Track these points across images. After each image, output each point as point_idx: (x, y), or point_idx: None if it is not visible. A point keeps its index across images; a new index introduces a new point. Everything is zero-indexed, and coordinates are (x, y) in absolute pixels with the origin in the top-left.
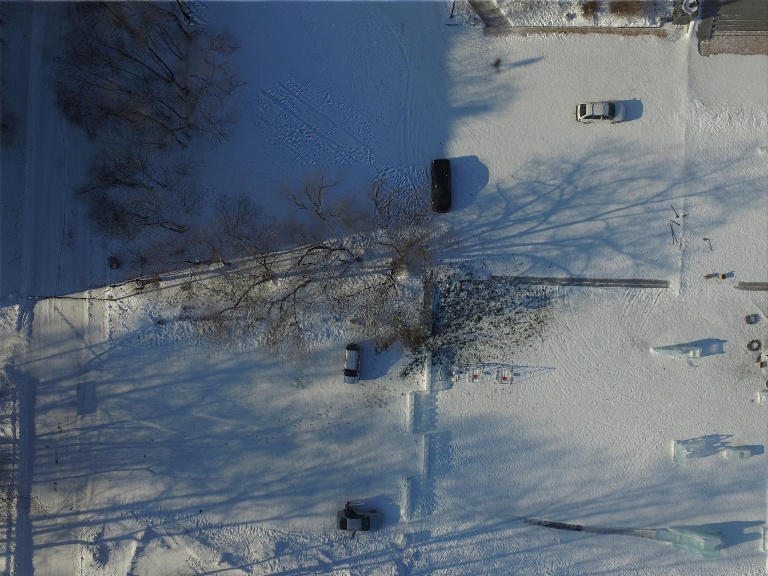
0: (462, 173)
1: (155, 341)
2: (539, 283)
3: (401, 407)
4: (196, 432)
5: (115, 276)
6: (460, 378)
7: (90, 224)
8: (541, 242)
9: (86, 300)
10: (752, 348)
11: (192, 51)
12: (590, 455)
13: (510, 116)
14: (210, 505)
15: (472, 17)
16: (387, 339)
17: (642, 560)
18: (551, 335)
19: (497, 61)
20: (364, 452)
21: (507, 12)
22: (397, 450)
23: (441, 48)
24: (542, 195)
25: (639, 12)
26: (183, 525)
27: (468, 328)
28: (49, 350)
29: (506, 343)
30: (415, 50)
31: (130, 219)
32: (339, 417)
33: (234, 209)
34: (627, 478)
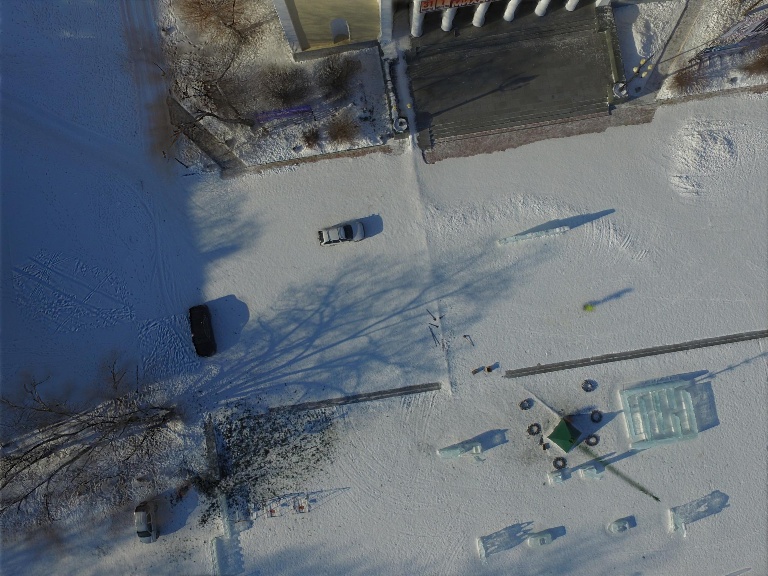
0: (223, 314)
1: None
2: (317, 407)
3: (206, 556)
4: None
5: None
6: (258, 515)
7: None
8: (310, 367)
9: None
10: (533, 432)
11: None
12: (400, 568)
13: (259, 251)
14: None
15: (207, 164)
16: (180, 489)
17: None
18: (339, 455)
19: (238, 201)
20: None
21: (239, 154)
22: None
23: (183, 198)
24: (303, 321)
25: (358, 136)
26: None
27: (257, 464)
28: None
29: (297, 472)
30: (158, 204)
31: None
32: None
33: None
34: None
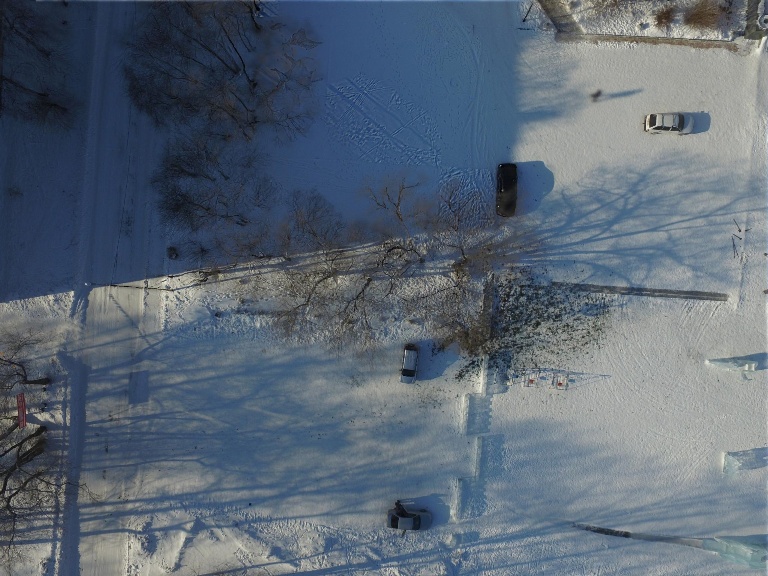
0: (527, 178)
1: (211, 333)
2: (599, 291)
3: (455, 408)
4: (248, 425)
5: (173, 266)
6: (515, 382)
7: (150, 213)
8: (603, 250)
9: (142, 289)
10: None
11: (261, 43)
12: (641, 463)
13: (578, 123)
14: (260, 499)
15: (544, 22)
16: (444, 340)
17: (688, 568)
18: (608, 343)
19: (567, 67)
20: (416, 452)
21: (580, 19)
22: (449, 451)
23: (512, 52)
24: (606, 203)
25: (713, 25)
26: (232, 517)
27: (526, 333)
28: (102, 338)
29: (563, 349)
30: (486, 53)
31: (195, 210)
32: (393, 416)
33: (306, 205)
34: (676, 487)
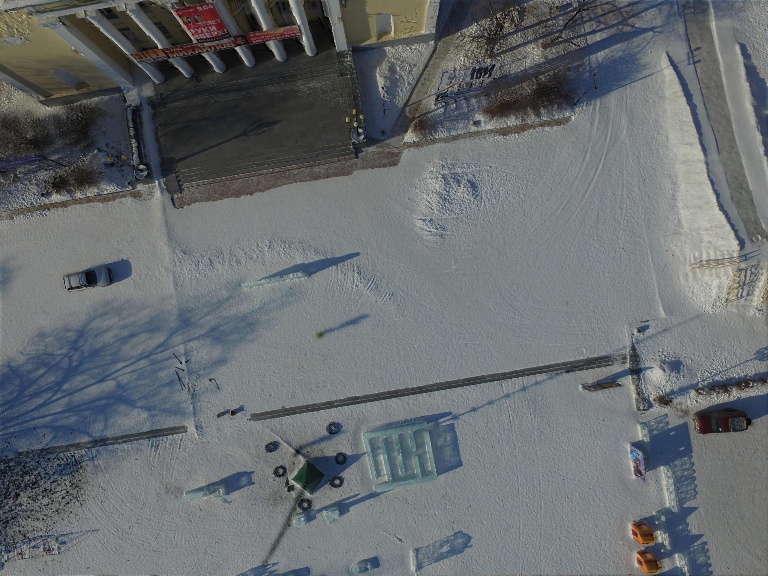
0: None
1: None
2: (66, 450)
3: None
4: None
5: None
6: (9, 557)
7: None
8: (59, 411)
9: None
10: (278, 474)
11: None
12: None
13: (11, 296)
14: None
15: None
16: None
17: None
18: (88, 498)
19: None
20: None
21: None
22: None
23: None
24: (52, 366)
25: (103, 182)
26: None
27: (8, 507)
28: None
29: (47, 514)
30: None
31: None
32: None
33: None
34: None
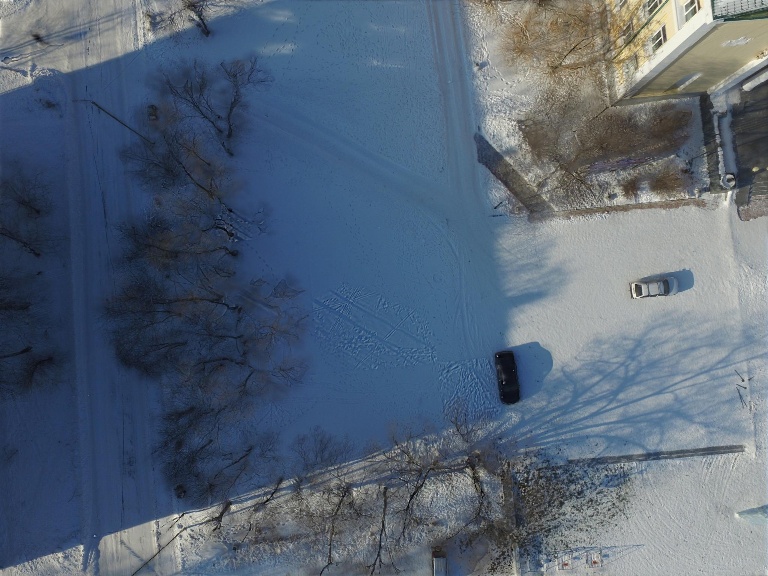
0: (526, 361)
1: (231, 566)
2: (616, 461)
3: None
4: None
5: (183, 504)
6: (549, 567)
7: None
8: (613, 421)
9: (154, 531)
10: None
11: (240, 268)
12: None
13: (565, 299)
14: None
15: (515, 206)
16: (470, 535)
17: None
18: (635, 512)
19: (545, 246)
20: None
21: (549, 198)
22: None
23: (489, 239)
24: (608, 374)
25: (678, 189)
26: None
27: (551, 515)
28: None
29: (591, 525)
30: (463, 244)
31: (198, 455)
32: None
33: (313, 449)
34: None
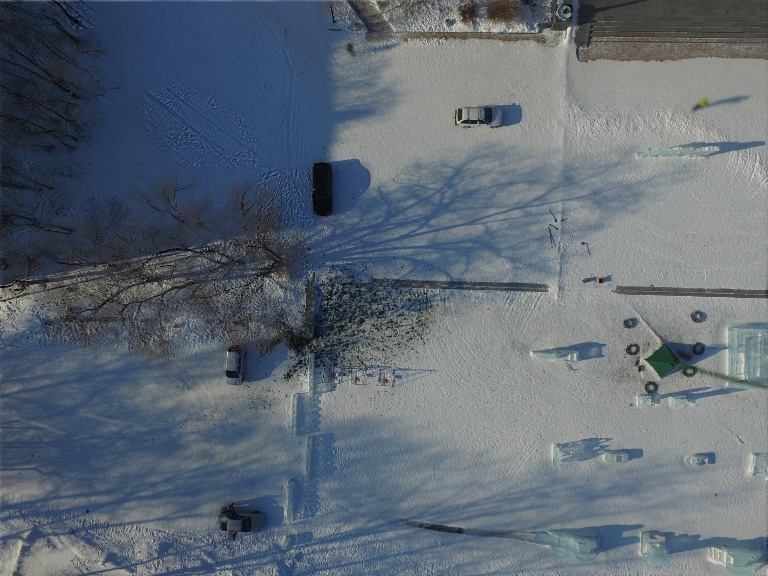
0: (344, 176)
1: (44, 342)
2: (420, 286)
3: (285, 409)
4: (84, 432)
5: (4, 277)
6: (343, 380)
7: None
8: (421, 245)
9: None
10: (631, 352)
11: (80, 55)
12: (471, 458)
13: (392, 120)
14: (97, 505)
15: (354, 22)
16: (271, 341)
17: (521, 563)
18: (432, 338)
19: (379, 66)
20: (249, 453)
21: (389, 17)
22: (281, 451)
23: (324, 53)
24: (423, 199)
25: (516, 18)
26: (69, 525)
27: (351, 330)
28: None
29: (388, 345)
30: (298, 55)
31: (12, 220)
32: (224, 418)
33: (103, 211)
34: (508, 481)
